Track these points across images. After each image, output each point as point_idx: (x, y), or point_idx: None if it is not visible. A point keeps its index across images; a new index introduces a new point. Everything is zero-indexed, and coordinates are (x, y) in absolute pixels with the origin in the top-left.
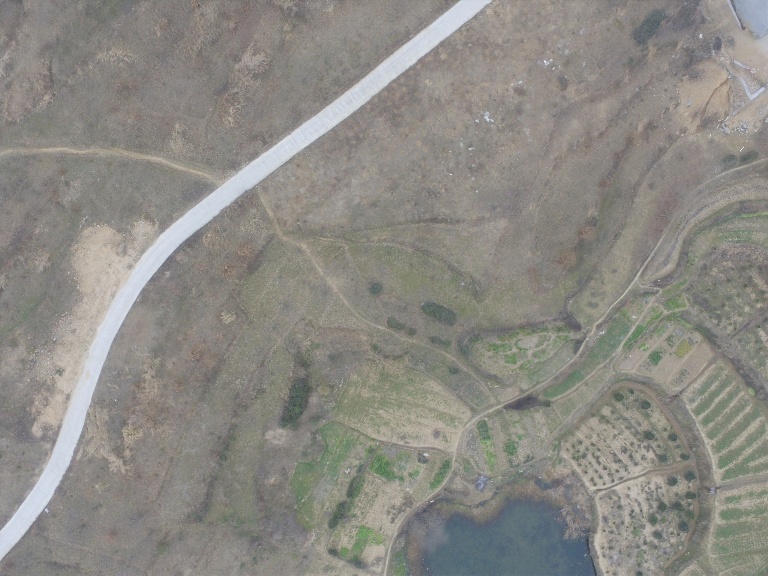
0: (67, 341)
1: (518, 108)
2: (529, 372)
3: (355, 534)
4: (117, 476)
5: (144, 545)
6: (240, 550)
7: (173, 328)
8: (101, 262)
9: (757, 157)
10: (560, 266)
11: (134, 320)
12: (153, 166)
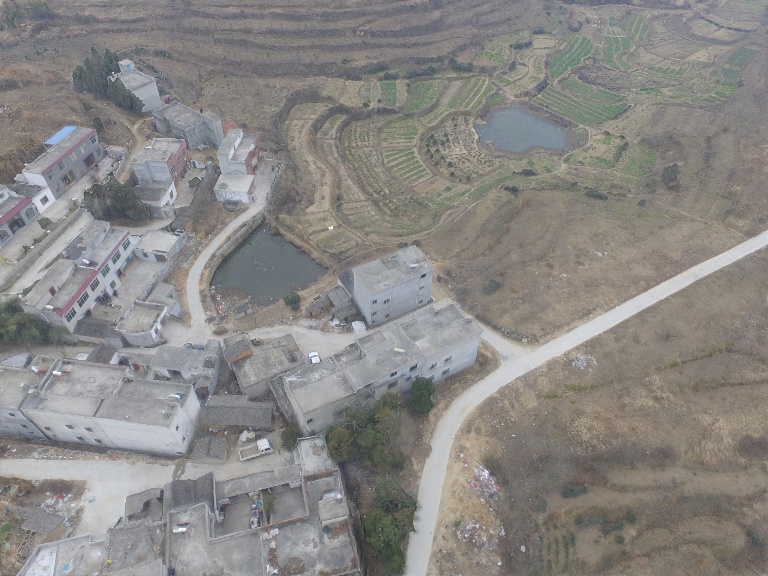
0: None
1: (579, 256)
2: None
3: (612, 142)
4: None
5: None
6: None
7: None
8: None
9: None
10: None
11: None
12: None
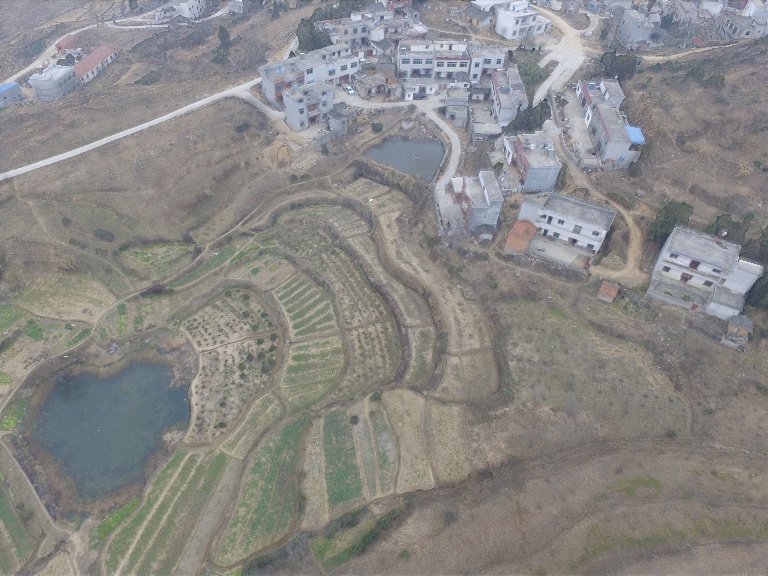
0: None
1: (169, 150)
2: (159, 270)
3: None
4: None
5: None
6: None
7: None
8: None
9: (311, 178)
10: (184, 212)
11: None
12: None
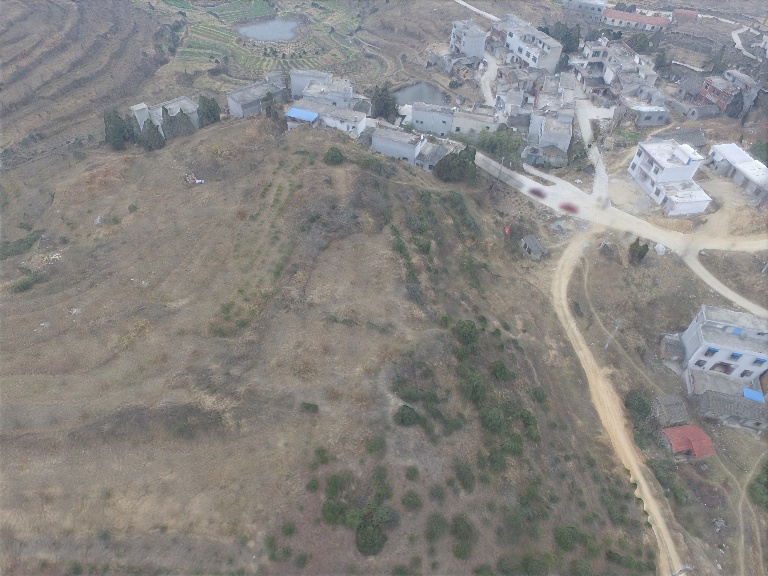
0: None
1: None
2: None
3: (307, 7)
4: None
5: None
6: None
7: None
8: None
9: None
10: None
11: None
12: None
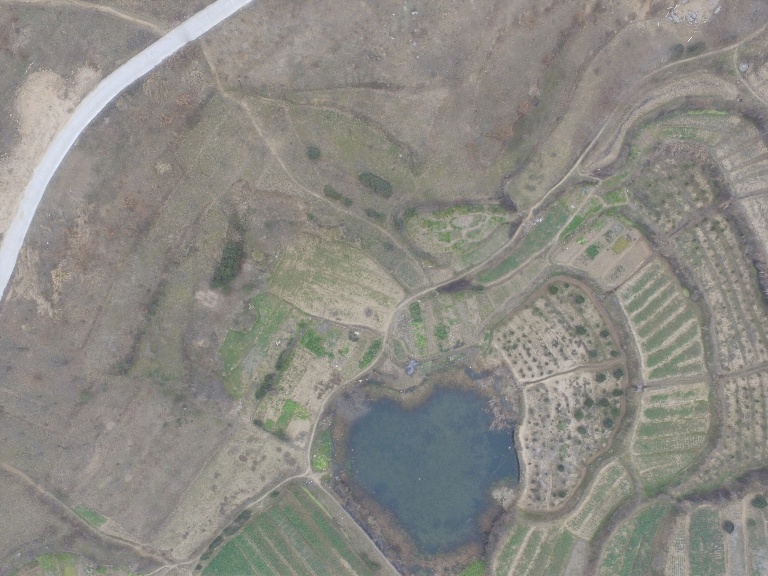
0: (3, 180)
1: None
2: (463, 253)
3: (282, 407)
4: (45, 319)
5: (68, 392)
6: (164, 408)
7: (109, 175)
8: (42, 104)
9: (705, 49)
10: (498, 143)
11: (71, 164)
12: (101, 14)
